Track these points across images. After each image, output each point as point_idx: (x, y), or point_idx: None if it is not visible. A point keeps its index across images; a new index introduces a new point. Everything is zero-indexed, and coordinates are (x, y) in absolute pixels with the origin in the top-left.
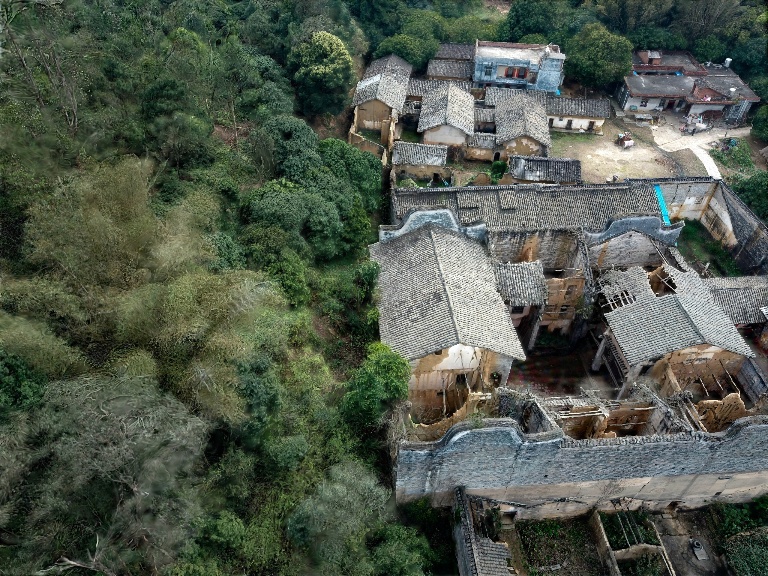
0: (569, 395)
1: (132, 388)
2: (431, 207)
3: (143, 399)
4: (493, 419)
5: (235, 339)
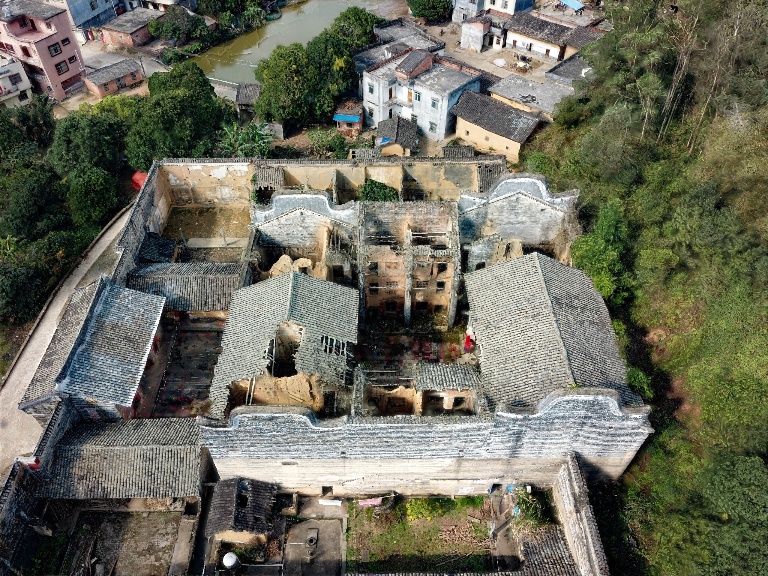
0: (380, 381)
1: (762, 47)
2: (587, 387)
3: (759, 82)
4: (519, 173)
5: (730, 126)
